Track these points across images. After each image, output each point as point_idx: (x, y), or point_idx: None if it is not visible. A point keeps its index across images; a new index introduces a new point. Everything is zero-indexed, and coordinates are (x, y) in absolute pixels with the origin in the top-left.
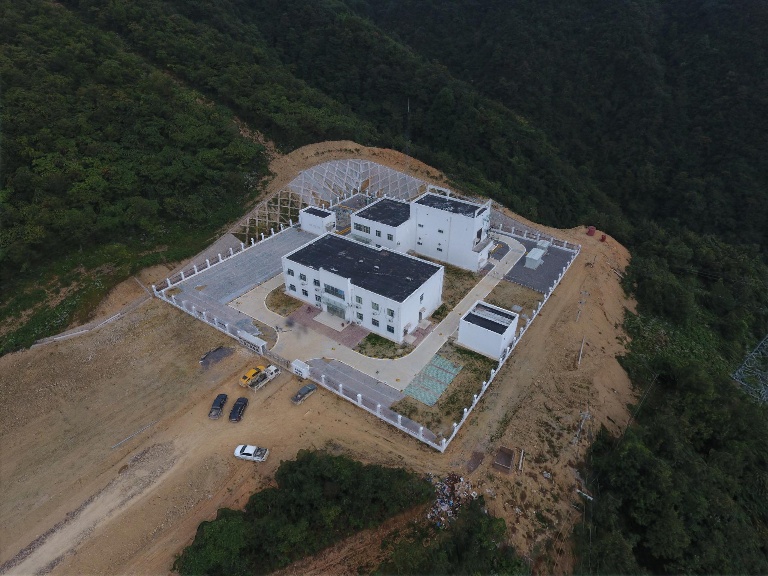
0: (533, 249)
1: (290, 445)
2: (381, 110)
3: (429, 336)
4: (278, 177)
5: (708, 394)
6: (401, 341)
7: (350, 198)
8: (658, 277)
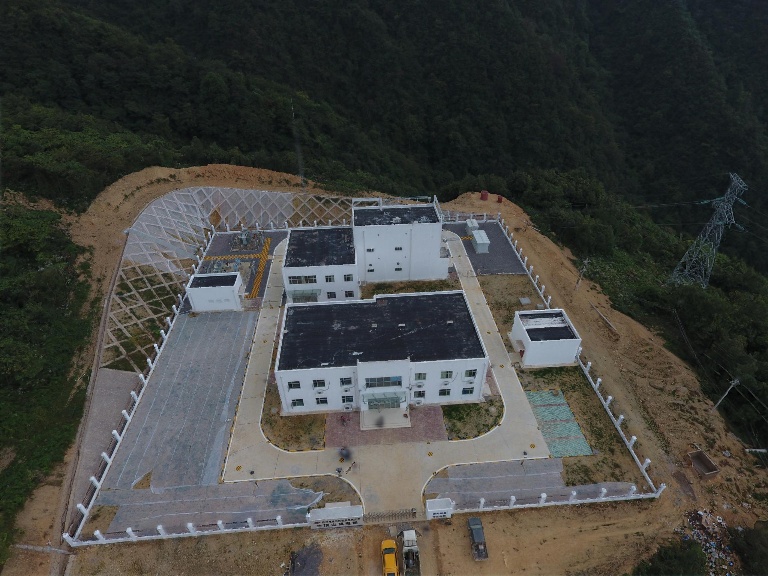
0: (474, 233)
1: None
2: (127, 114)
3: (496, 375)
4: (97, 250)
5: (732, 310)
6: (481, 397)
7: (210, 243)
8: (586, 221)
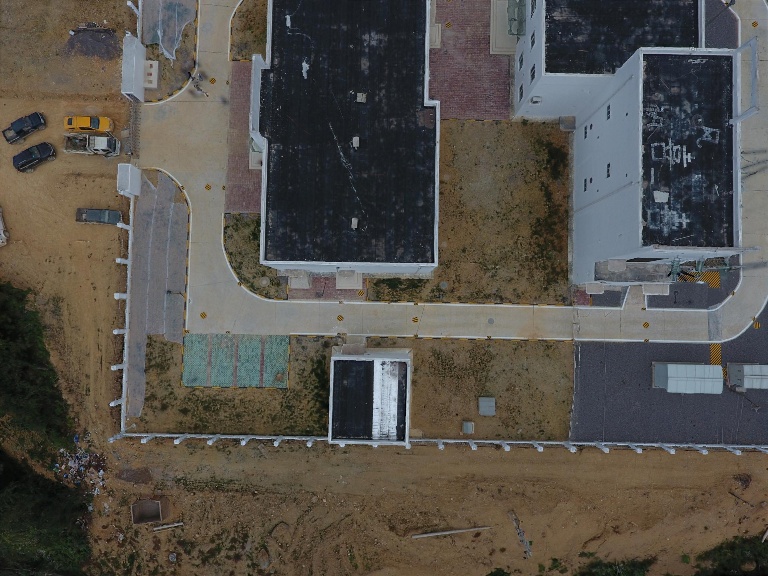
0: (713, 367)
1: (31, 258)
2: None
3: (324, 304)
4: None
5: None
6: None
7: None
8: None
